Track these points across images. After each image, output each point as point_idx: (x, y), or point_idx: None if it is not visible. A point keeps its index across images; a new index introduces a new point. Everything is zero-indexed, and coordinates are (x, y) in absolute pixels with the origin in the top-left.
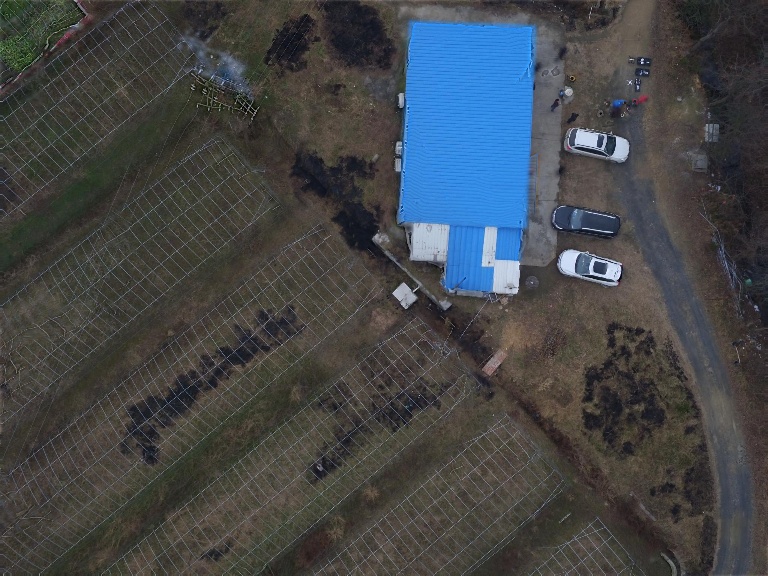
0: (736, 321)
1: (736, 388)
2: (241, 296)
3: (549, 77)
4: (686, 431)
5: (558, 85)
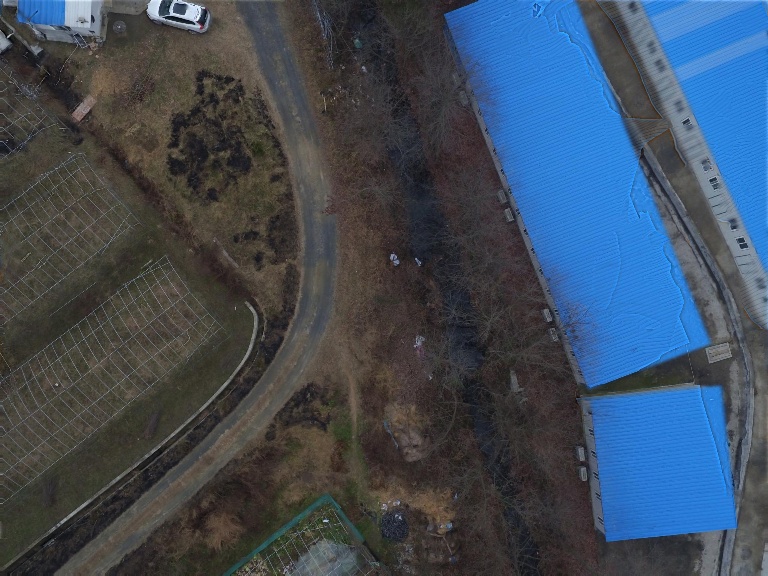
0: (328, 73)
1: (324, 138)
2: None
3: None
4: (272, 179)
5: None
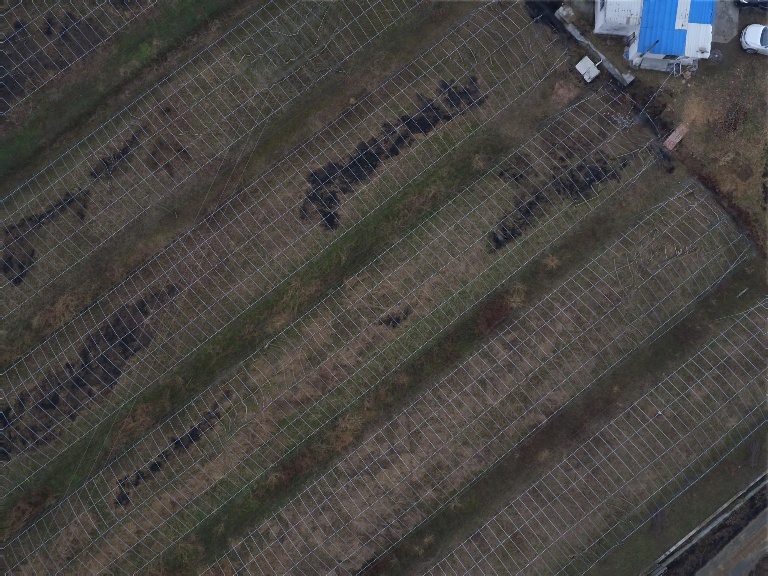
0: None
1: None
2: (434, 55)
3: None
4: None
5: None
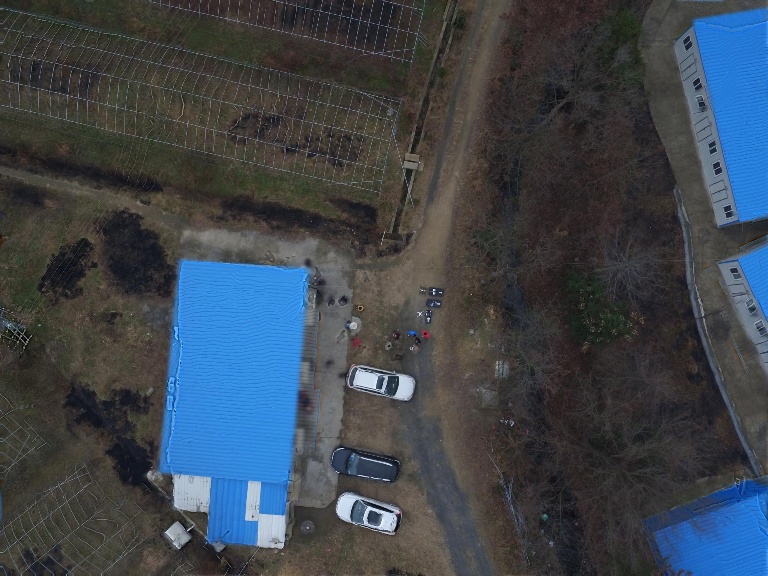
0: (524, 568)
1: None
2: None
3: (336, 307)
4: None
5: (345, 315)
